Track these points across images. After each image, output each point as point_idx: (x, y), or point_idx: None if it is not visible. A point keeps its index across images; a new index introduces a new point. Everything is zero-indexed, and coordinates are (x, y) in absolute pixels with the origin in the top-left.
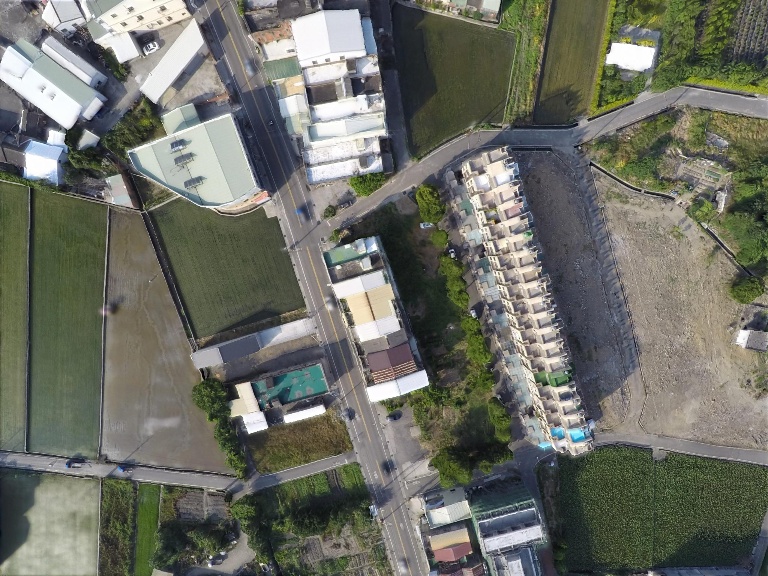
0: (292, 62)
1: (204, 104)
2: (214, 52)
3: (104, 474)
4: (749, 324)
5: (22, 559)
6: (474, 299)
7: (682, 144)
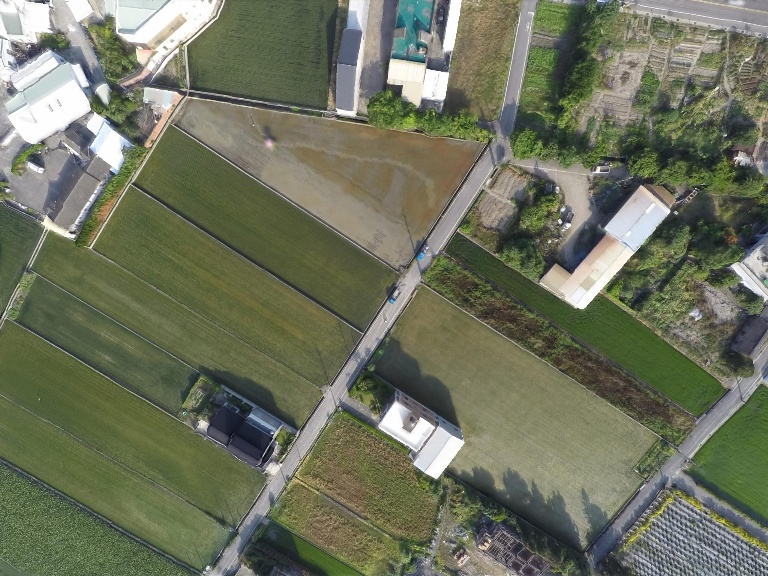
0: None
1: None
2: None
3: (418, 277)
4: None
5: (463, 402)
6: None
7: None
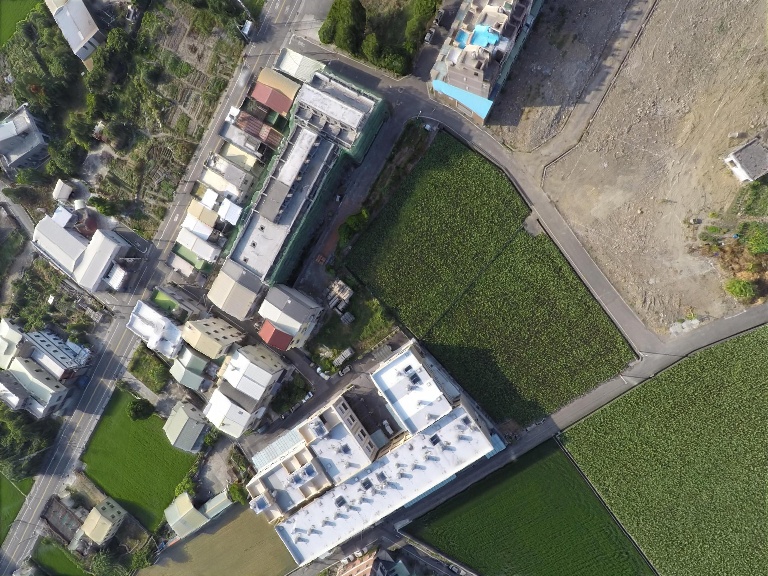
0: None
1: None
2: None
3: None
4: None
5: None
6: None
7: None
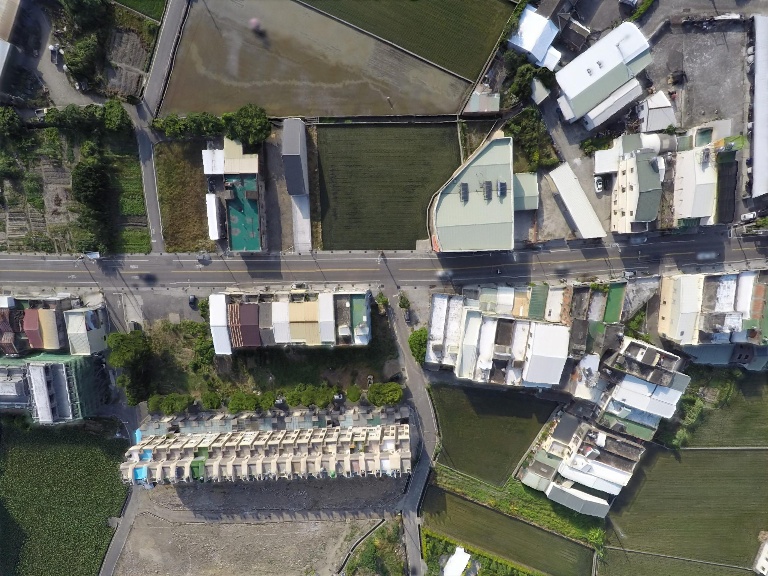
0: (541, 311)
1: (535, 217)
2: (575, 241)
3: None
4: None
5: None
6: None
7: None
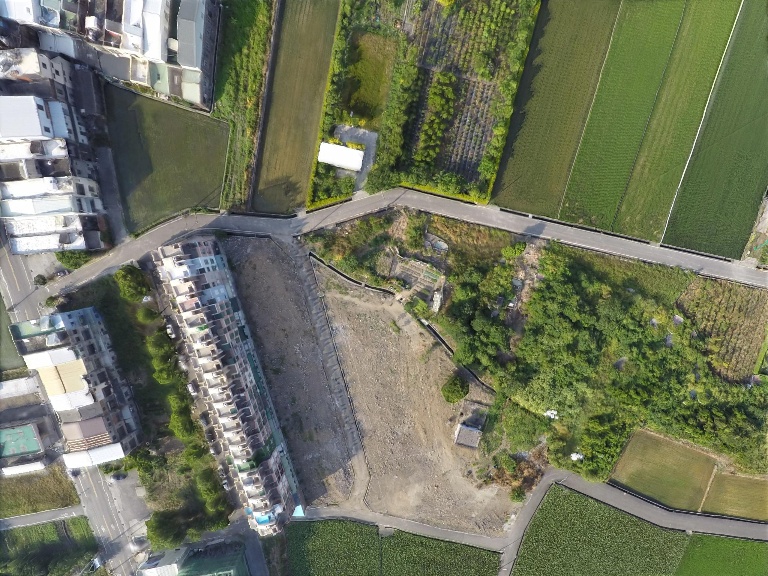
0: None
1: None
2: None
3: None
4: (468, 419)
5: None
6: (194, 373)
7: (400, 243)
